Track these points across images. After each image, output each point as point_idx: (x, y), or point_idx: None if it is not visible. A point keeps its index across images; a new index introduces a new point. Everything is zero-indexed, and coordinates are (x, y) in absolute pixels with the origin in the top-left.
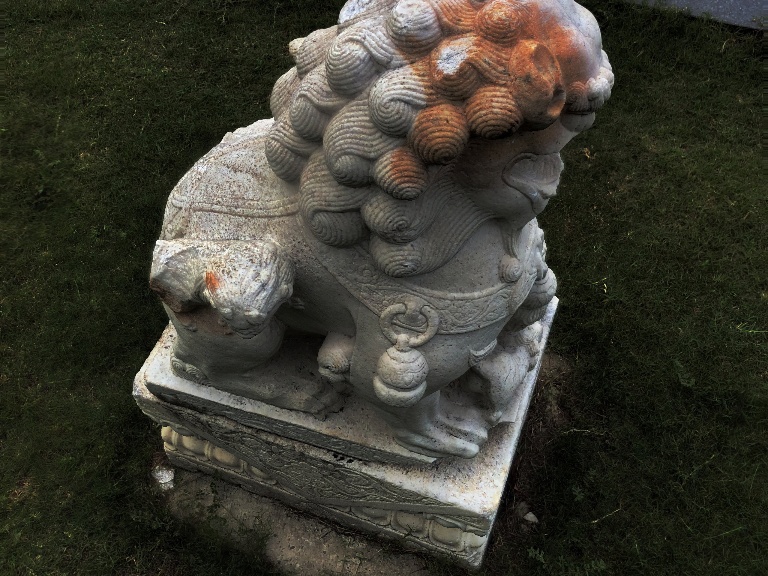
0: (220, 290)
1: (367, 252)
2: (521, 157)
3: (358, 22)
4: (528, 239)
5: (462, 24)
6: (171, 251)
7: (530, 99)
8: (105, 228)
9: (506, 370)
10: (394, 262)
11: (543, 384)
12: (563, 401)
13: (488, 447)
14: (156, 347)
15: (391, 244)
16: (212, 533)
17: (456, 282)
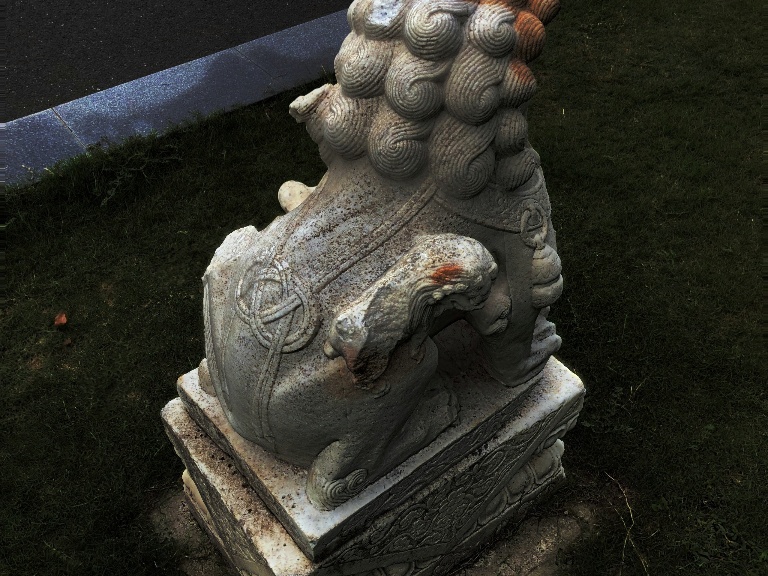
0: (465, 267)
1: (494, 184)
2: None
3: (413, 8)
4: None
5: None
6: (358, 314)
7: None
8: None
9: None
10: (528, 165)
11: None
12: None
13: None
14: (257, 541)
15: (519, 153)
16: None
17: (532, 177)
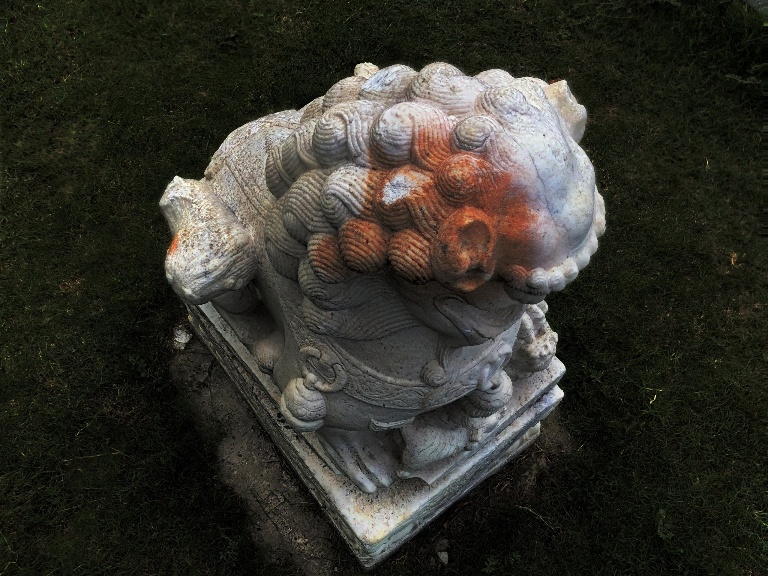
0: (172, 257)
1: None
2: (453, 297)
3: (363, 100)
4: (480, 353)
5: (428, 160)
6: (180, 192)
7: (440, 266)
8: (261, 97)
9: (426, 444)
10: (310, 319)
11: (536, 450)
12: (543, 476)
13: (405, 488)
14: None
15: None
16: (186, 406)
17: (374, 360)
